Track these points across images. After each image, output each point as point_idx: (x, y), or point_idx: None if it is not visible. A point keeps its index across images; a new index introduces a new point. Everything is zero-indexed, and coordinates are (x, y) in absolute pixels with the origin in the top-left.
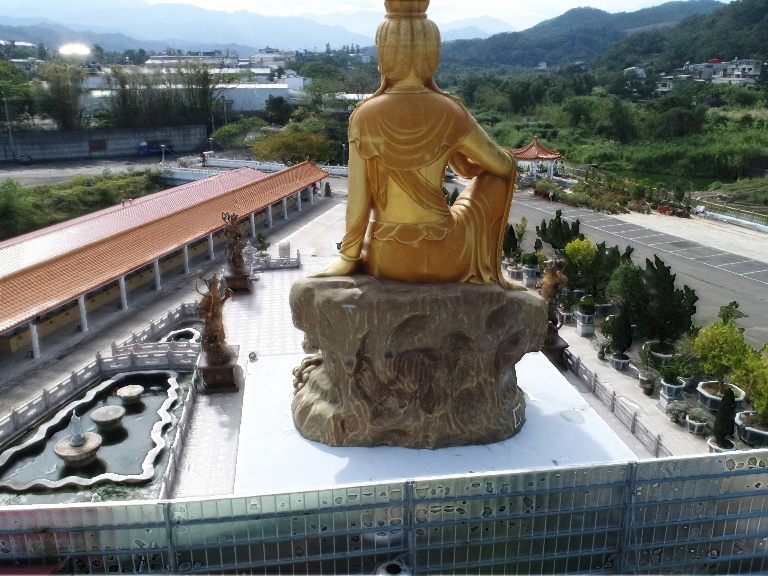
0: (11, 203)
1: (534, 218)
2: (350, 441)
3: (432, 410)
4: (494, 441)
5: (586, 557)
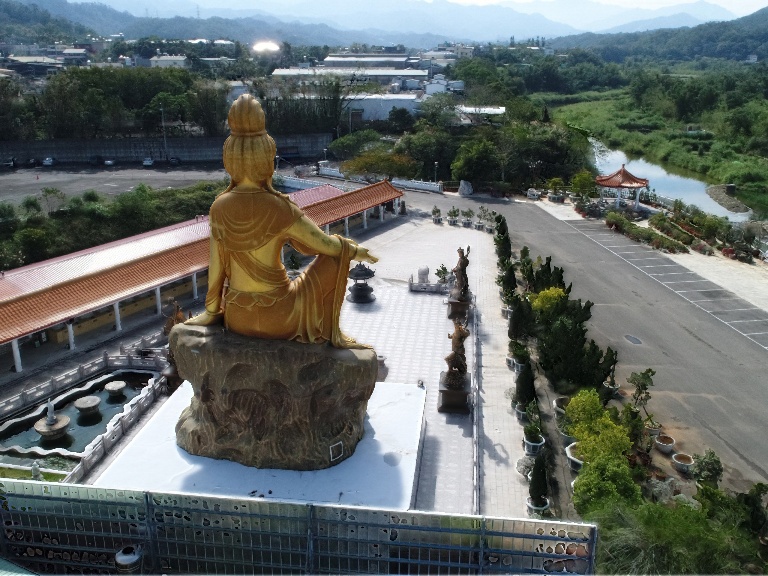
0: (136, 206)
1: (582, 252)
2: (203, 452)
3: (261, 438)
4: (309, 469)
5: (286, 570)
